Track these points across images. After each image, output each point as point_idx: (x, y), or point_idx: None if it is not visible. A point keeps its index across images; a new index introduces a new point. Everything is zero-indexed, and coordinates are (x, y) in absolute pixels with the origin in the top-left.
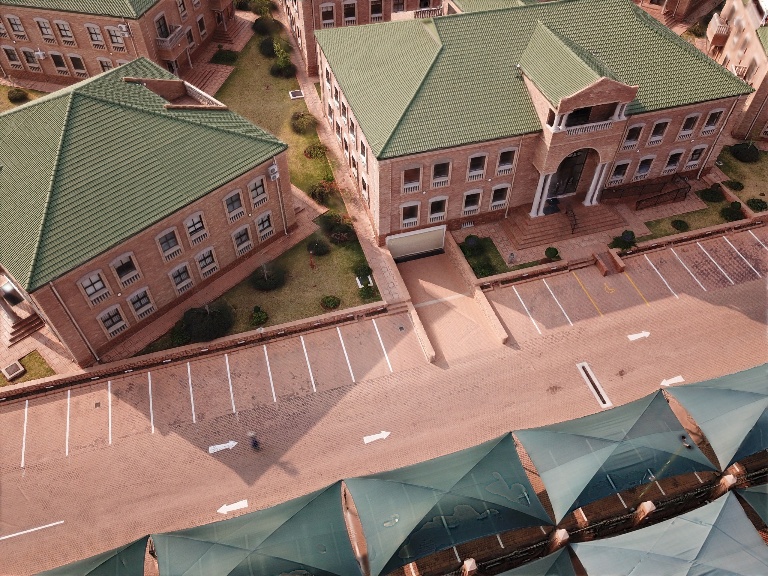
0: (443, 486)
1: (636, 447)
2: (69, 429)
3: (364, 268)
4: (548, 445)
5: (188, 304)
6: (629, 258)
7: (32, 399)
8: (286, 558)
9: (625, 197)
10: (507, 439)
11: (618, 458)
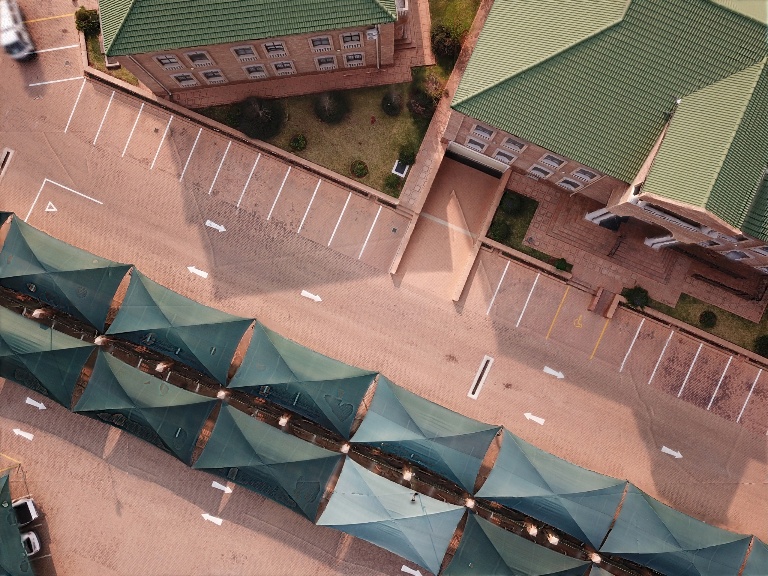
0: (300, 376)
1: (432, 449)
2: (131, 137)
3: (409, 156)
4: (388, 401)
5: (257, 87)
6: (627, 311)
7: (118, 92)
8: (187, 345)
9: (695, 259)
10: (369, 377)
11: (415, 445)
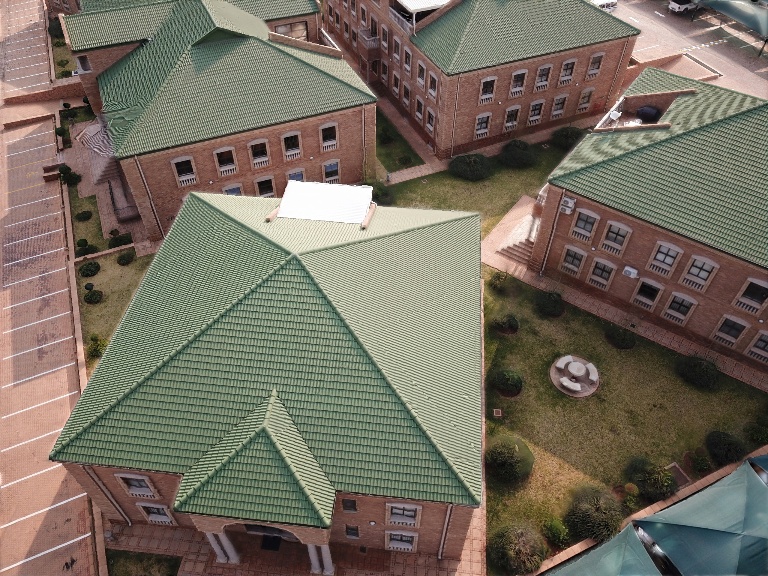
0: None
1: None
2: None
3: None
4: None
5: None
6: (58, 185)
7: None
8: None
9: None
10: None
11: None
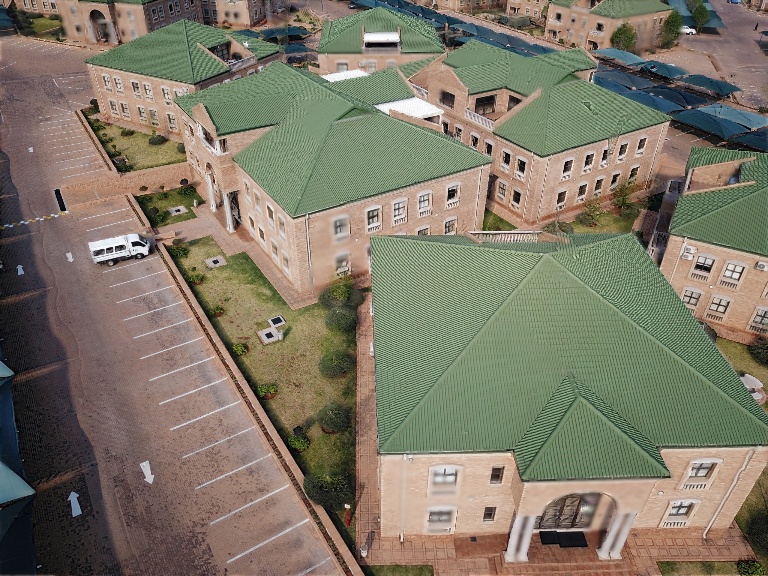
0: None
1: None
2: None
3: None
4: None
5: None
6: None
7: None
8: None
9: None
10: None
11: None
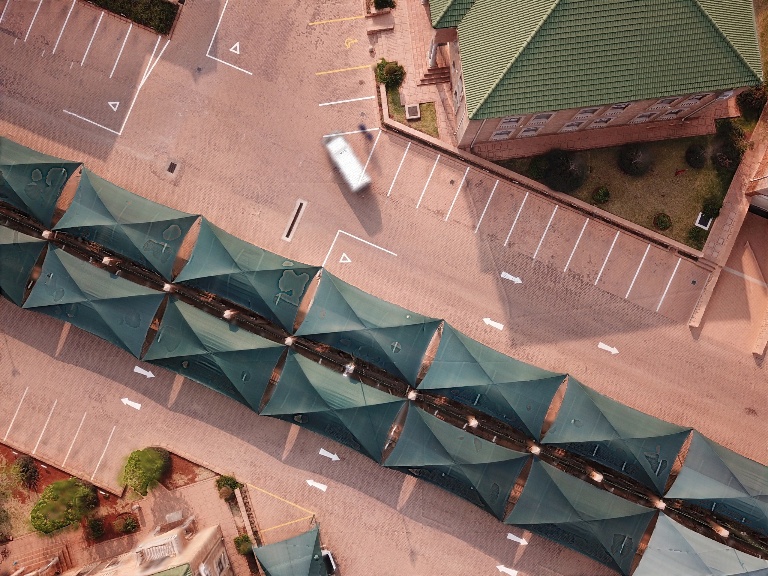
0: (622, 433)
1: (756, 506)
2: (426, 188)
3: (715, 209)
4: (706, 457)
5: (560, 140)
6: None
7: (414, 144)
8: (509, 402)
9: None
10: (686, 433)
11: (738, 502)
